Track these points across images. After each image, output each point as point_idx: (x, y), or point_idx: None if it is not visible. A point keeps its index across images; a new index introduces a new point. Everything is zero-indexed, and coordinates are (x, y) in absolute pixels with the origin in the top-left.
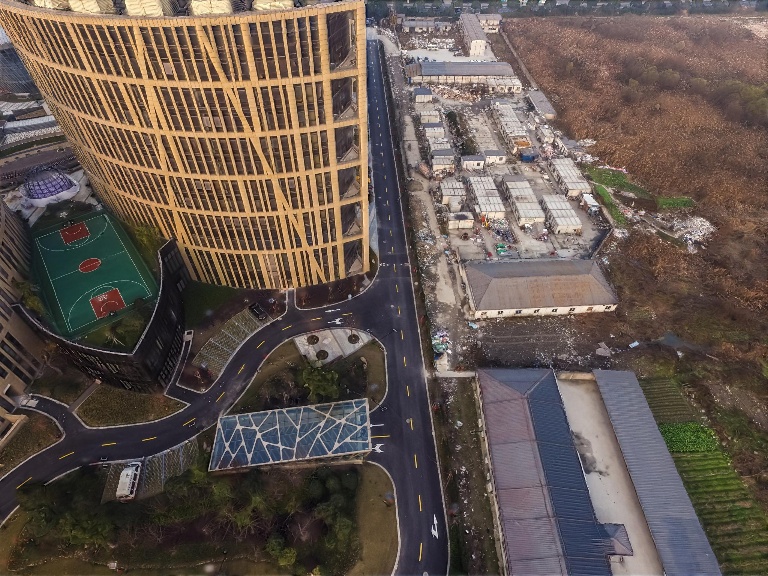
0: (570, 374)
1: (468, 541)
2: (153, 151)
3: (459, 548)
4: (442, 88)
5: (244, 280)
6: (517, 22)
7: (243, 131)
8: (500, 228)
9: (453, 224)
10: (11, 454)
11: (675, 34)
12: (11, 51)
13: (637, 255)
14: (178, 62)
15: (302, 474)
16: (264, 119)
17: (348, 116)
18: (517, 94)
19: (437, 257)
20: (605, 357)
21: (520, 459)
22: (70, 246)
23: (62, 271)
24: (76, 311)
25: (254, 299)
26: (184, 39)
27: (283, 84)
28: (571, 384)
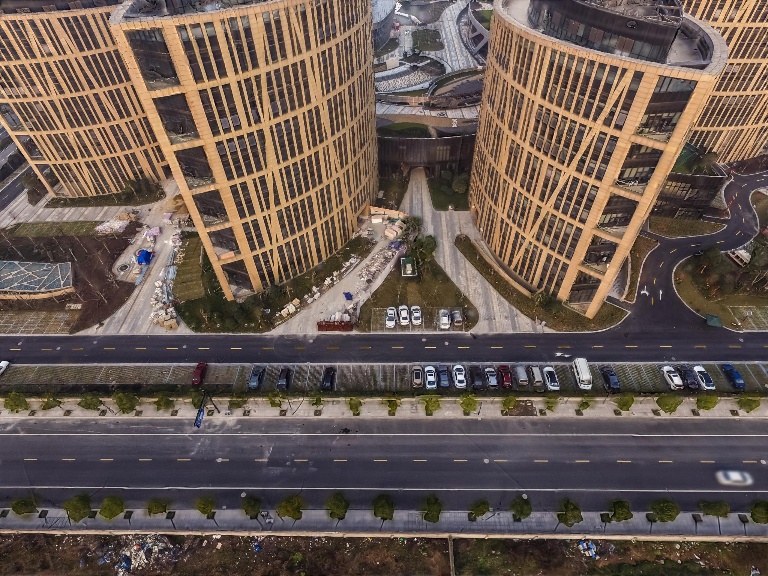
0: None
1: None
2: None
3: None
4: None
5: None
6: None
7: None
8: None
9: None
10: (637, 250)
11: None
12: None
13: None
14: None
15: None
16: None
17: None
18: None
19: None
20: None
21: None
22: None
23: None
24: None
25: None
26: None
27: None
28: None
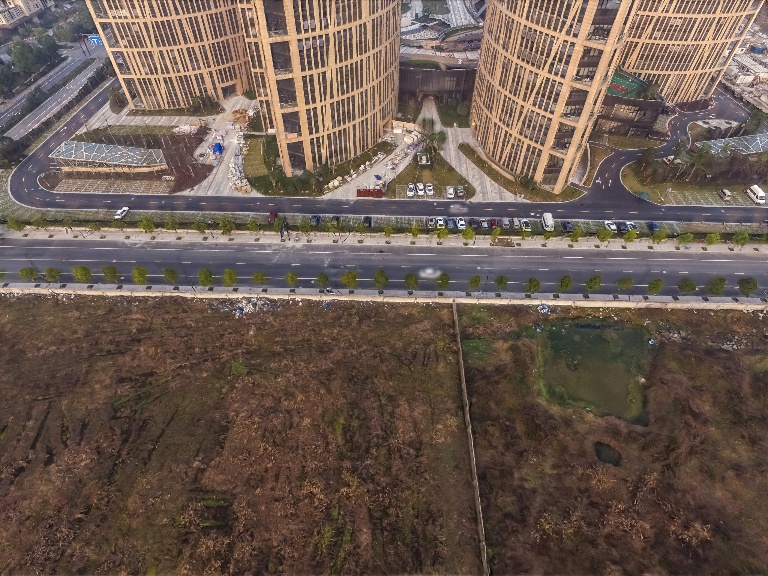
0: None
1: None
2: None
3: None
4: None
5: None
6: None
7: None
8: None
9: (740, 79)
10: None
11: None
12: None
13: None
14: None
15: None
16: None
17: None
18: None
19: None
20: None
21: None
22: None
23: None
24: None
25: None
26: None
27: None
28: None
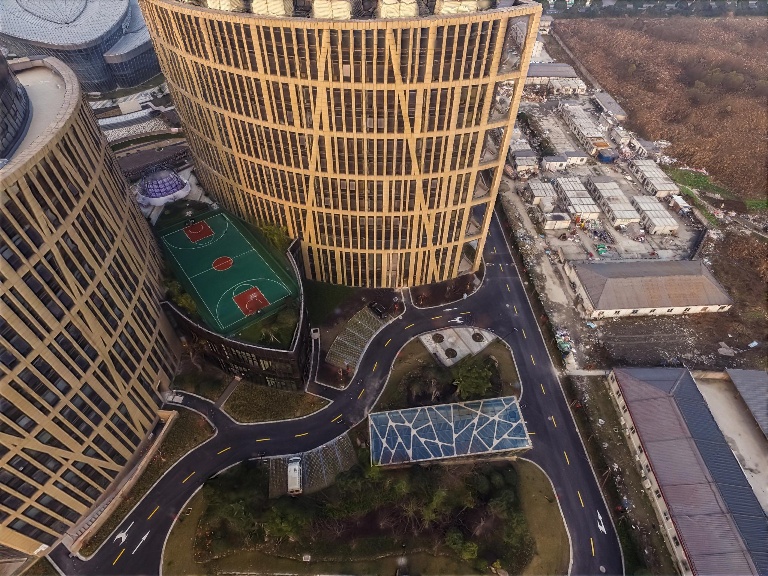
0: (702, 373)
1: (637, 536)
2: (305, 151)
3: (631, 543)
4: (506, 89)
5: (361, 279)
6: (566, 23)
7: (403, 132)
8: (595, 229)
9: (550, 224)
10: (171, 449)
11: (727, 36)
12: (88, 51)
13: (737, 256)
14: (357, 64)
15: (461, 470)
16: (426, 120)
17: (497, 118)
18: (581, 95)
19: (539, 257)
20: (729, 357)
21: (679, 456)
22: (198, 244)
23: (197, 269)
24: (222, 309)
25: (371, 298)
26: (371, 42)
27: (453, 86)
28: (702, 383)
